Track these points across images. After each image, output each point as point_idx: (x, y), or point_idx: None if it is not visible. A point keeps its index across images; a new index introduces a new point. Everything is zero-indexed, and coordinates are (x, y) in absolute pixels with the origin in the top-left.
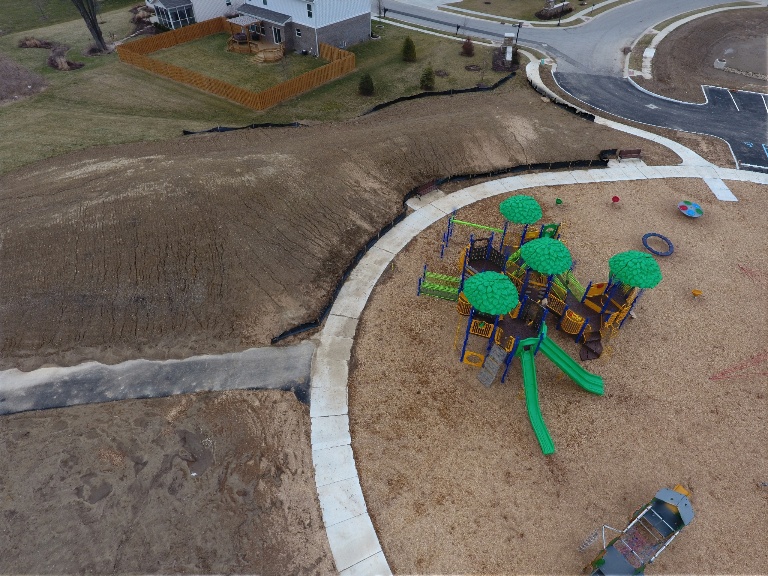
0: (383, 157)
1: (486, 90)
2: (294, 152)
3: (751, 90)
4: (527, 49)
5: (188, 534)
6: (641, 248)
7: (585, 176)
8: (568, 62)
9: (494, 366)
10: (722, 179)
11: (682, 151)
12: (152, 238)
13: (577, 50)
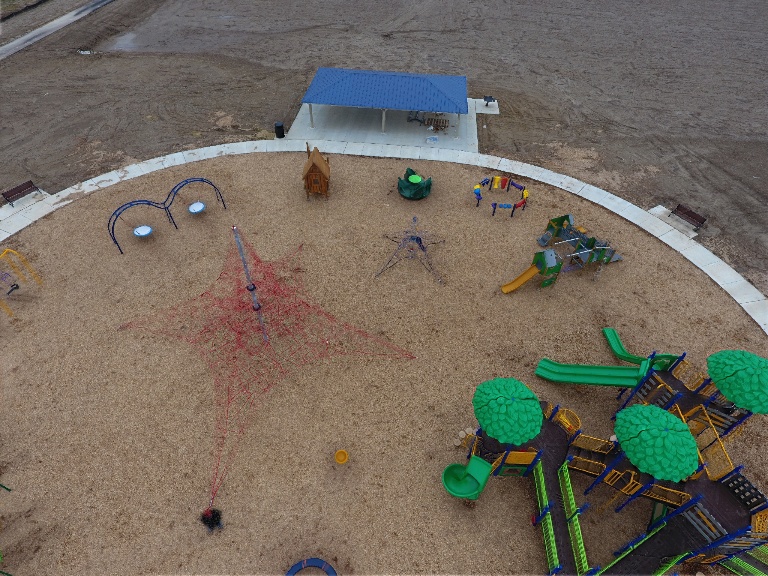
0: None
1: None
2: None
3: None
4: None
5: None
6: None
7: None
8: None
9: None
10: None
11: None
12: None
13: None
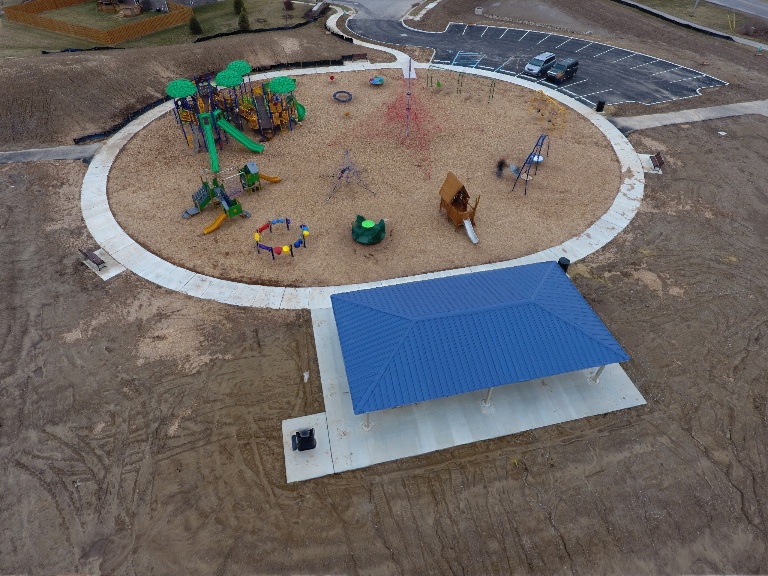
0: (182, 60)
1: (289, 29)
2: (114, 55)
3: (482, 24)
4: (340, 6)
5: (4, 202)
6: (333, 100)
7: (324, 70)
8: (366, 13)
9: (195, 137)
10: (415, 68)
11: (401, 56)
12: (4, 96)
13: (378, 5)
